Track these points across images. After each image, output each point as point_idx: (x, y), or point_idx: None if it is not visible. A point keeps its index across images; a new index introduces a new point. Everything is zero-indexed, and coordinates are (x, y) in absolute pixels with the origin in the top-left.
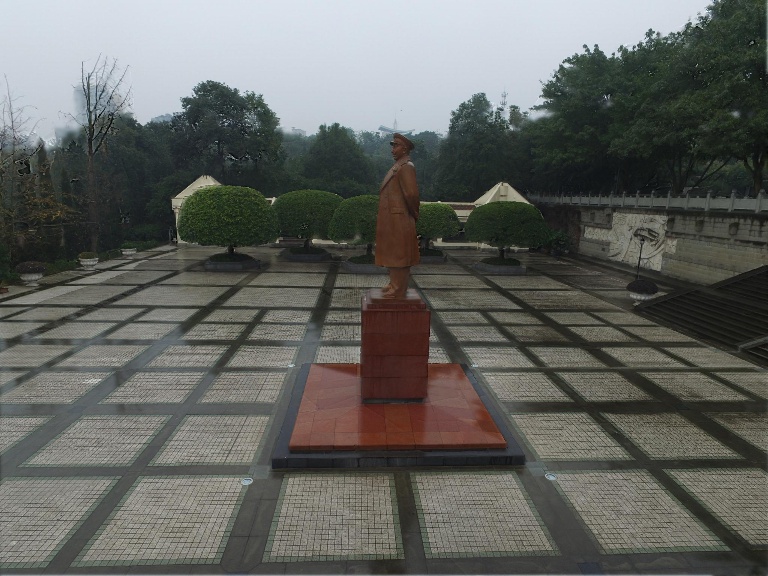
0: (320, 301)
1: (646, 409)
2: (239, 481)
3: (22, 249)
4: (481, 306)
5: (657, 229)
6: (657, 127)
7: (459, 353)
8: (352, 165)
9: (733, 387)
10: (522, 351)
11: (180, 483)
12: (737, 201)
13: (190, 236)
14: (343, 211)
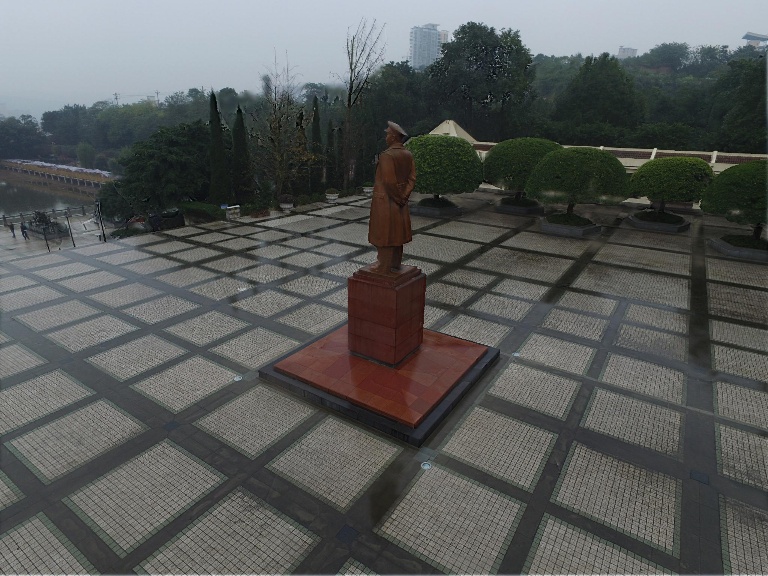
0: (464, 258)
1: (642, 460)
2: (234, 377)
3: (295, 183)
4: (634, 295)
5: None
6: None
7: (520, 338)
8: (612, 104)
9: None
10: (596, 355)
11: (209, 366)
12: None
13: None
14: (541, 165)
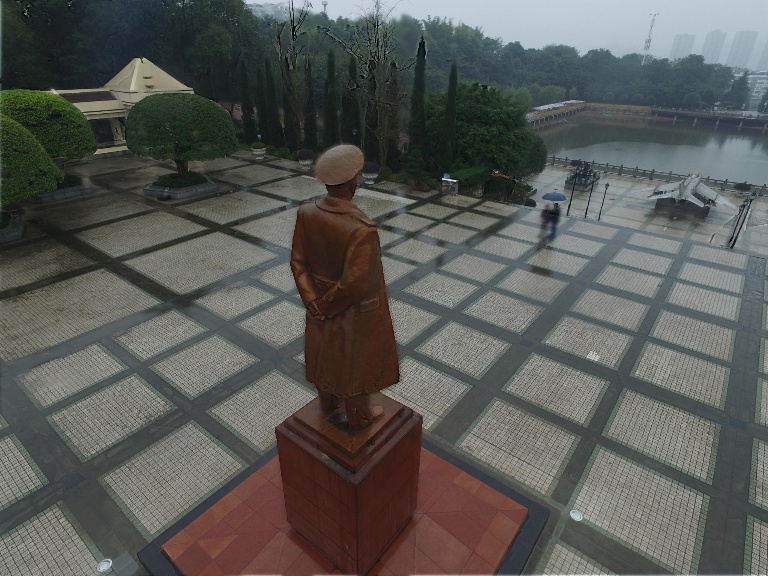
0: None
1: None
2: None
3: None
4: None
5: None
6: None
7: None
8: None
9: None
10: None
11: None
12: None
13: None
14: None
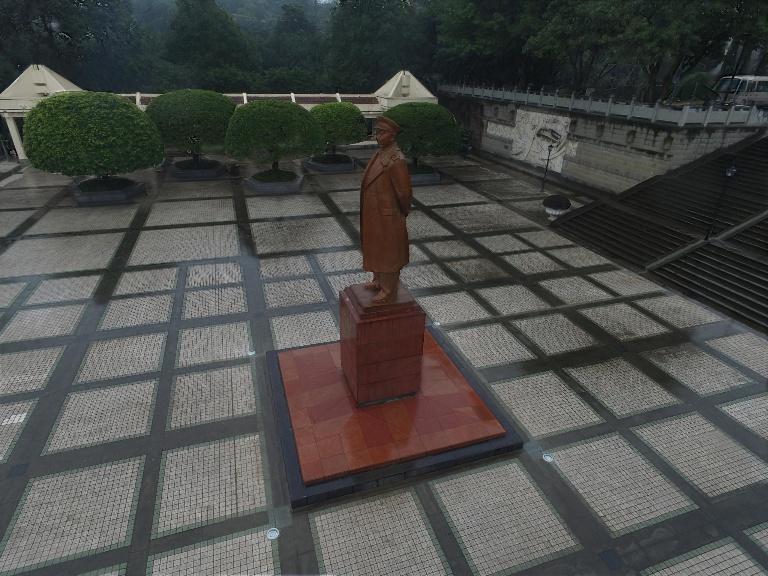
0: (243, 245)
1: (597, 357)
2: (265, 536)
3: None
4: (414, 235)
5: (560, 131)
6: (571, 25)
7: None
8: (229, 46)
9: (653, 317)
10: (473, 296)
11: (201, 555)
12: (636, 109)
13: (48, 165)
14: (241, 122)
